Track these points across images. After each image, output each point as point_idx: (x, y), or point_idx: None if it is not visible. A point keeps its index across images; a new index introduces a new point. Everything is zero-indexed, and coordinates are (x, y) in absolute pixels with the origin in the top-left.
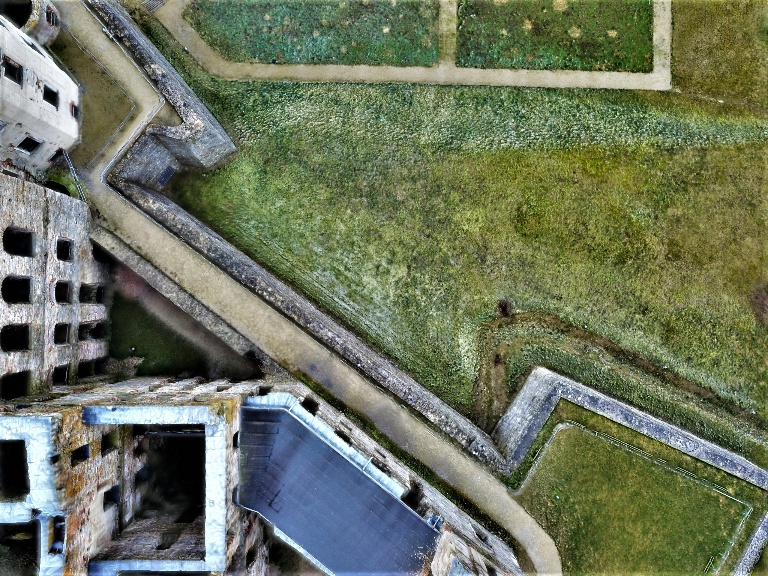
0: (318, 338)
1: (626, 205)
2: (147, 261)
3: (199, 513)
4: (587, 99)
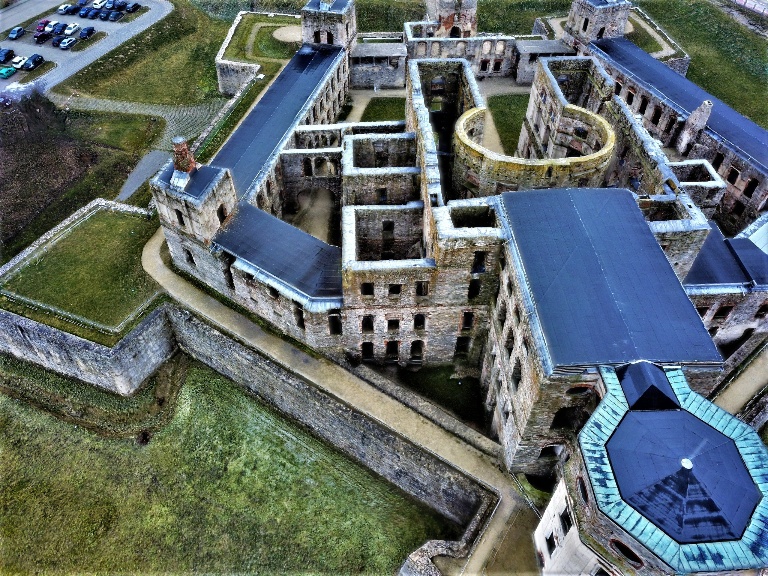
0: (300, 379)
1: None
2: (449, 431)
3: None
4: None
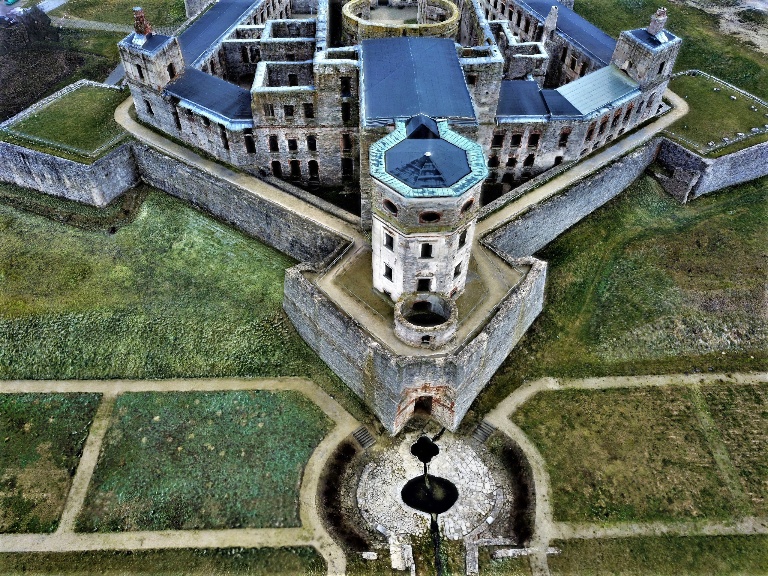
0: (225, 182)
1: (4, 282)
2: (326, 211)
3: (292, 115)
4: (1, 370)
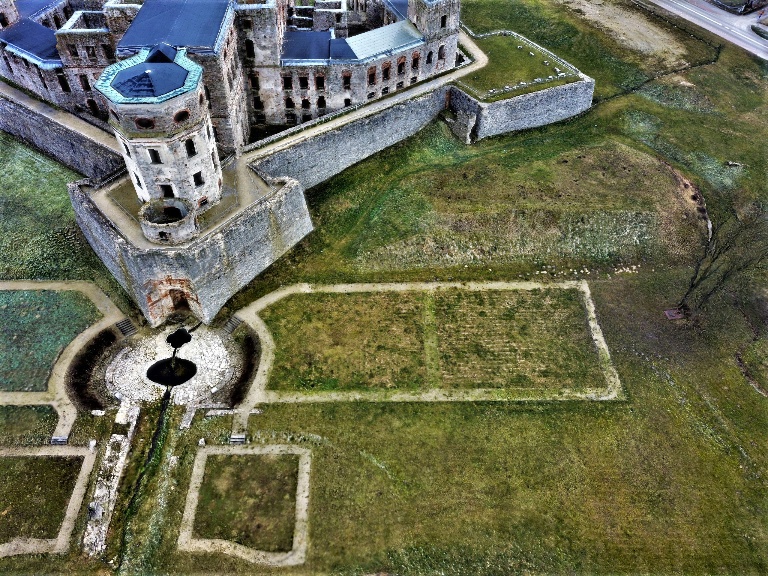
0: None
1: None
2: None
3: None
4: None
